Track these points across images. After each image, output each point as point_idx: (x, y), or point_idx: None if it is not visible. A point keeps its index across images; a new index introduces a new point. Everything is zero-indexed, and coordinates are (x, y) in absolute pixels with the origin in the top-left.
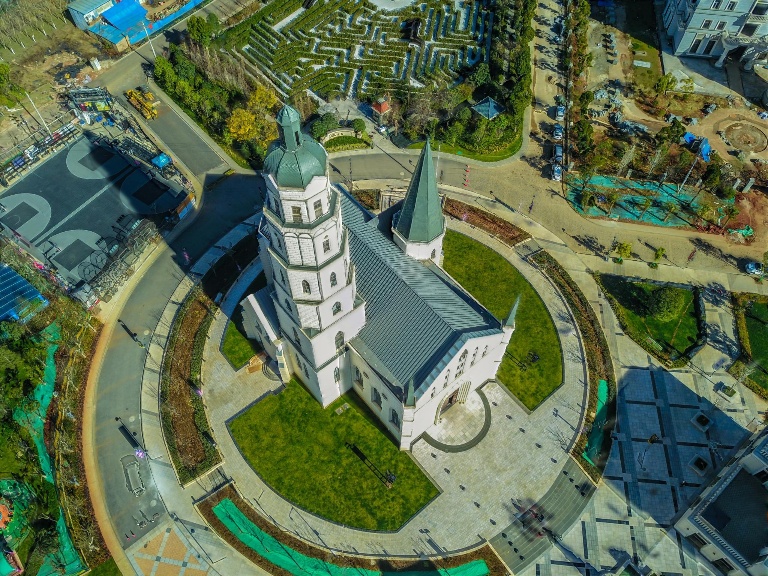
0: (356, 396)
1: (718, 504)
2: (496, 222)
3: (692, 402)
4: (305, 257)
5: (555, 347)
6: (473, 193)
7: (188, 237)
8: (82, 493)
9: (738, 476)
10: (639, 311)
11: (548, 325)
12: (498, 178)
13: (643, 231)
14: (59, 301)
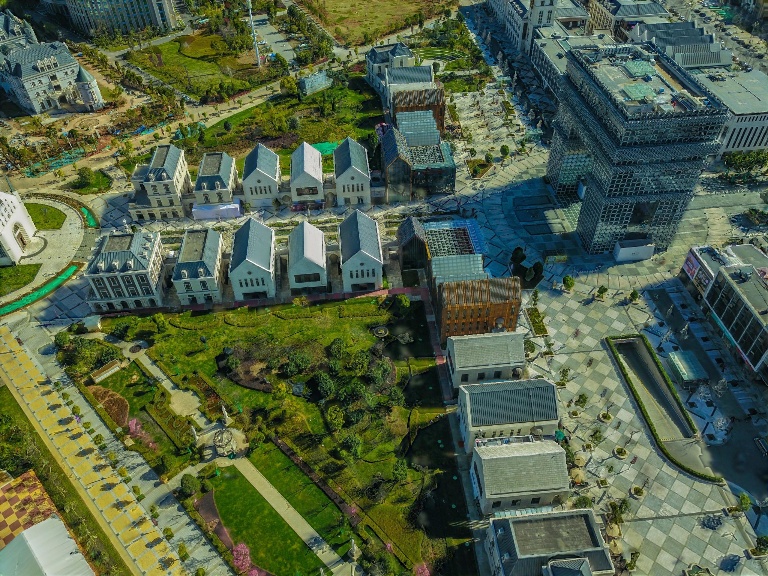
0: None
1: None
2: None
3: (119, 195)
4: None
5: (56, 211)
6: None
7: None
8: None
9: (137, 193)
10: (83, 187)
11: (48, 208)
12: None
13: (67, 168)
14: None
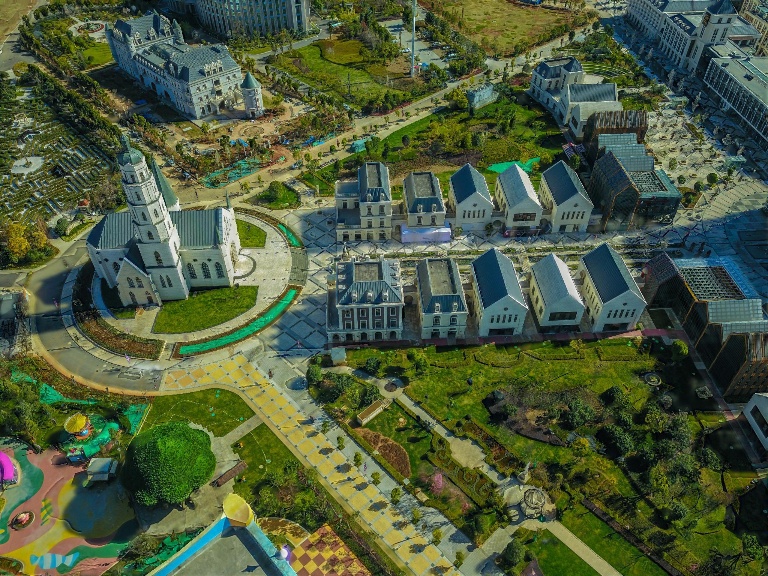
0: (196, 288)
1: None
2: None
3: (312, 211)
4: (151, 196)
5: (253, 227)
6: None
7: (42, 306)
8: (115, 395)
9: (339, 212)
10: (270, 201)
11: (243, 223)
12: None
13: (247, 179)
14: (3, 366)
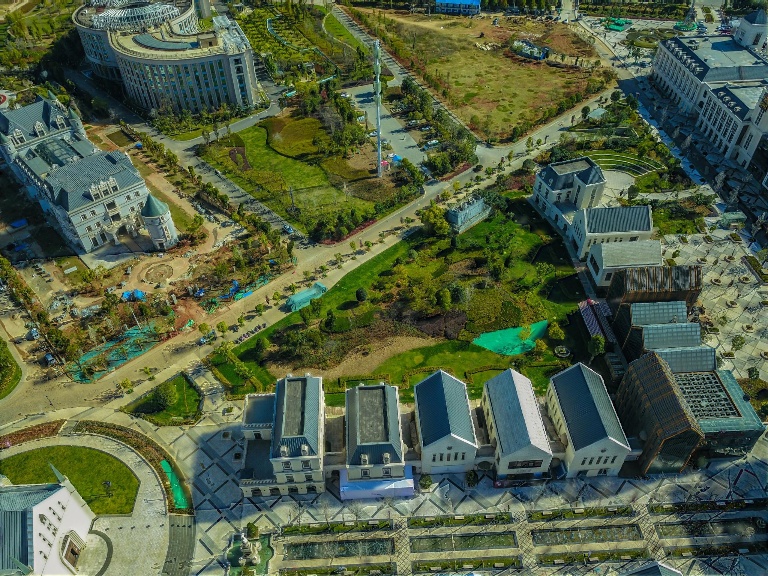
0: None
1: (249, 467)
2: (36, 429)
3: (216, 430)
4: None
5: (122, 468)
6: (7, 424)
7: None
8: None
9: (249, 446)
10: (160, 409)
11: (110, 460)
12: (19, 402)
13: (134, 364)
14: None
